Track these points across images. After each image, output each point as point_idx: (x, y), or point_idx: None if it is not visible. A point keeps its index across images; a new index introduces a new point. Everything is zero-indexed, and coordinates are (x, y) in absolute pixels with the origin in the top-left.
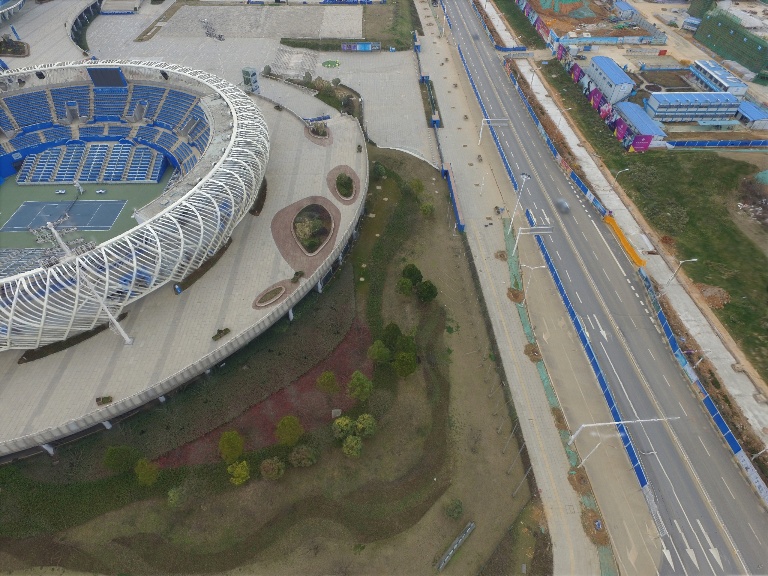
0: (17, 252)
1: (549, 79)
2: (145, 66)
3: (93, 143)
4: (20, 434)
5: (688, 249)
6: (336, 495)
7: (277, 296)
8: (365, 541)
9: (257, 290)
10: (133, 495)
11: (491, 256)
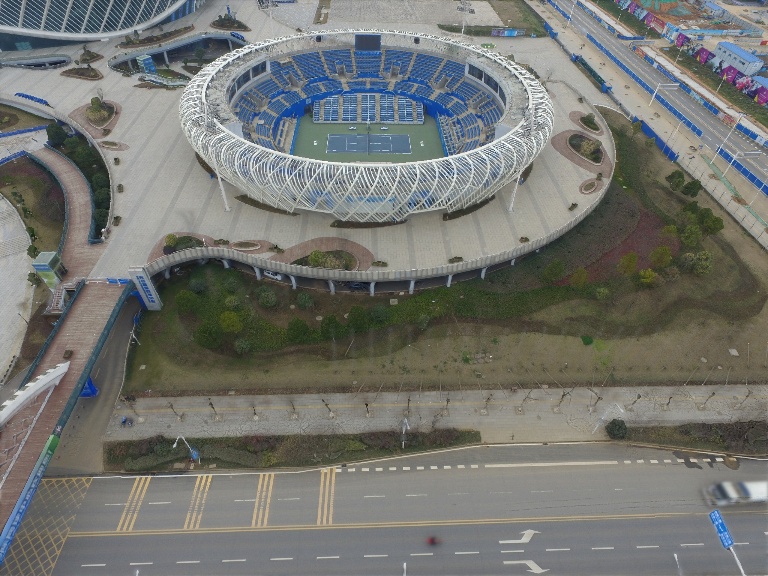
0: None
1: (677, 61)
2: (402, 34)
3: (360, 94)
4: None
5: None
6: (699, 298)
7: (595, 187)
8: (733, 320)
9: (576, 184)
10: (563, 297)
11: (706, 177)
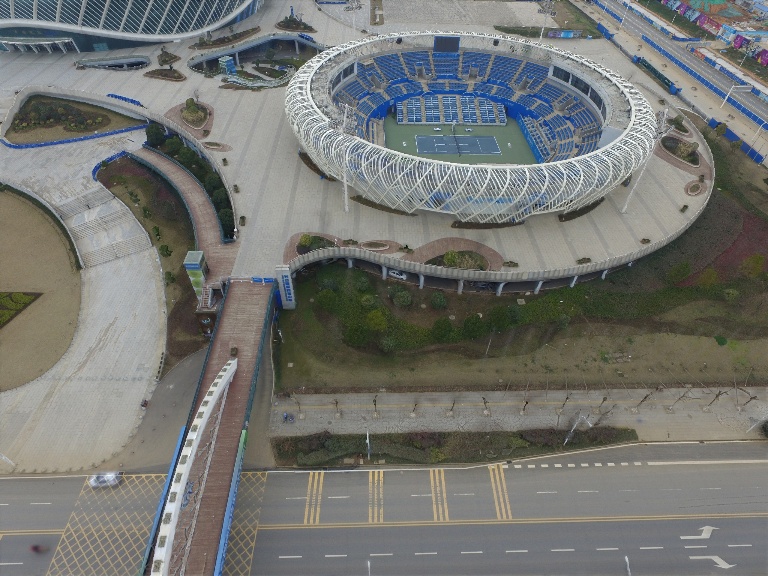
0: None
1: (737, 63)
2: (482, 36)
3: (440, 95)
4: (609, 257)
5: None
6: None
7: (700, 189)
8: None
9: (680, 186)
10: (689, 297)
11: None
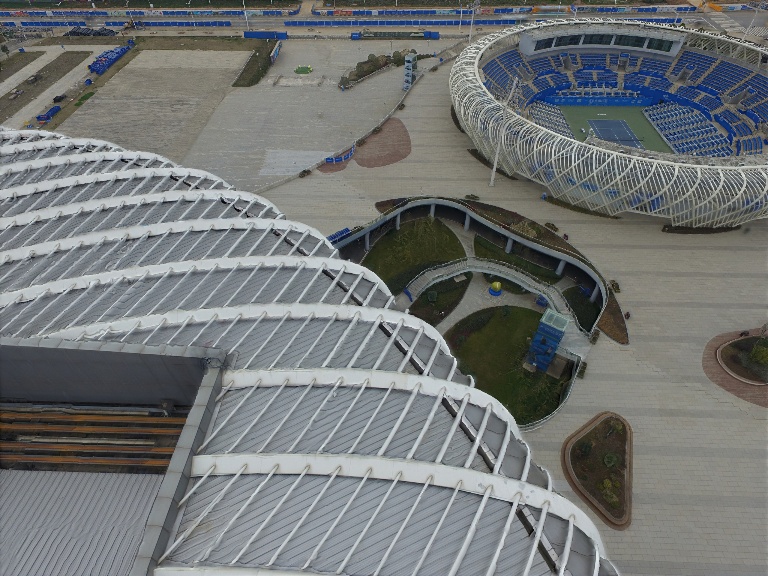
0: None
1: (359, 6)
2: None
3: None
4: None
5: (550, 2)
6: None
7: None
8: None
9: None
10: None
11: None
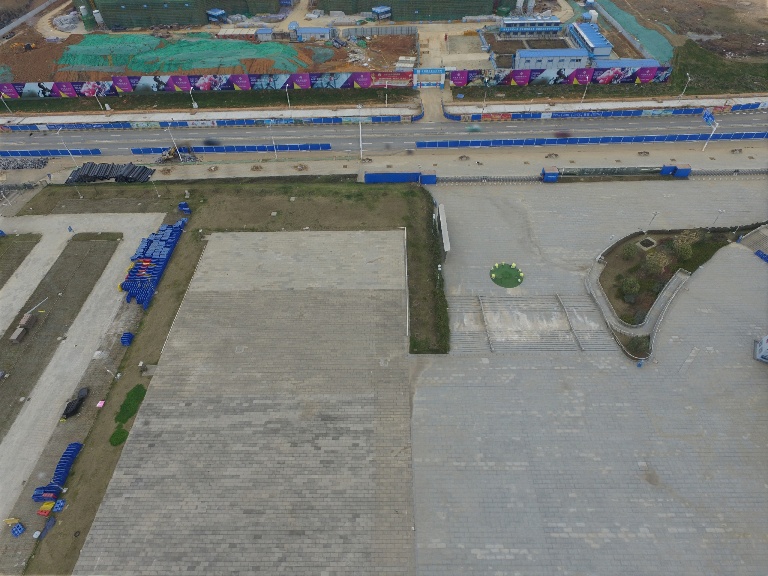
0: None
1: (510, 99)
2: None
3: None
4: None
5: None
6: None
7: None
8: None
9: None
10: None
11: None
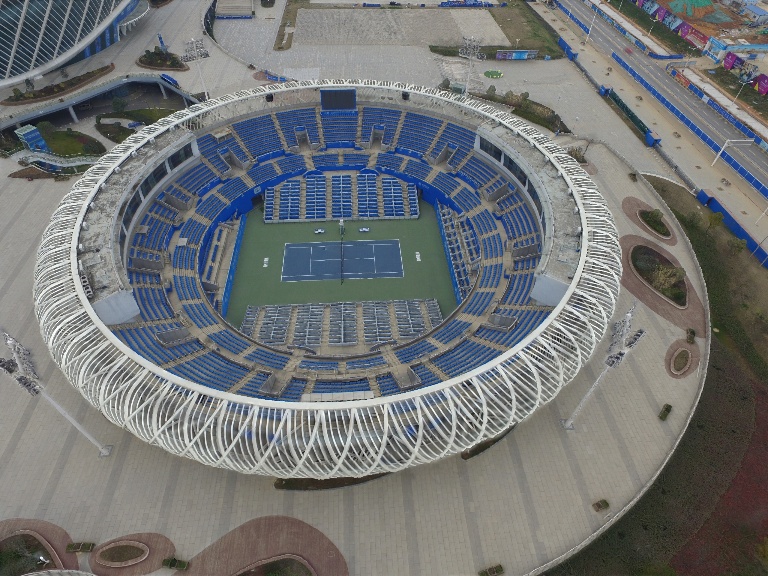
0: (323, 307)
1: (729, 90)
2: (385, 87)
3: (329, 173)
4: (536, 554)
5: None
6: None
7: (690, 361)
8: None
9: (659, 354)
10: None
11: None
